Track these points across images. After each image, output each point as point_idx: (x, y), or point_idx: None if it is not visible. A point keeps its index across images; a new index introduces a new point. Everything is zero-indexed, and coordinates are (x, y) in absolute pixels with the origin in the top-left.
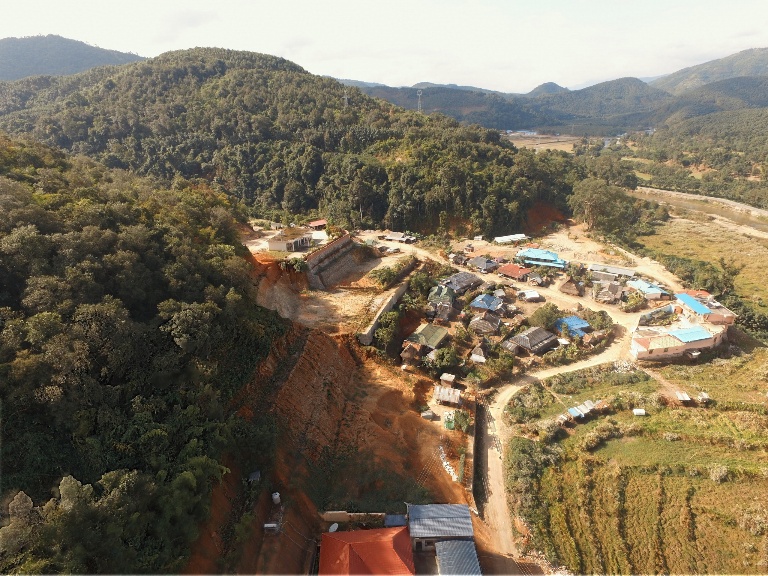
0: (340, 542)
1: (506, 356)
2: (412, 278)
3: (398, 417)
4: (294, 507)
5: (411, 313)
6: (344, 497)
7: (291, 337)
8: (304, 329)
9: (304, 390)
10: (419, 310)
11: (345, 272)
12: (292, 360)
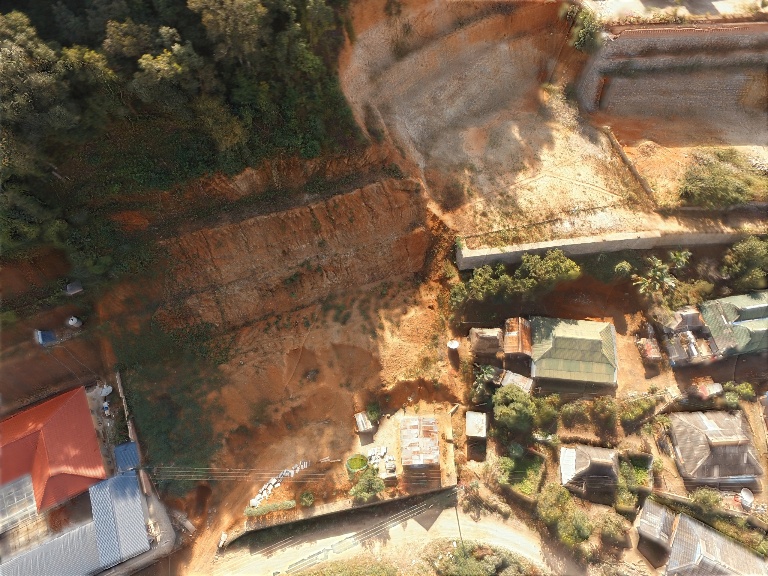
0: (52, 415)
1: (577, 527)
2: (759, 239)
3: (323, 385)
4: (92, 342)
5: (639, 288)
6: (150, 382)
7: (340, 166)
8: (390, 167)
9: (259, 249)
10: (647, 301)
11: (688, 108)
12: (291, 200)
